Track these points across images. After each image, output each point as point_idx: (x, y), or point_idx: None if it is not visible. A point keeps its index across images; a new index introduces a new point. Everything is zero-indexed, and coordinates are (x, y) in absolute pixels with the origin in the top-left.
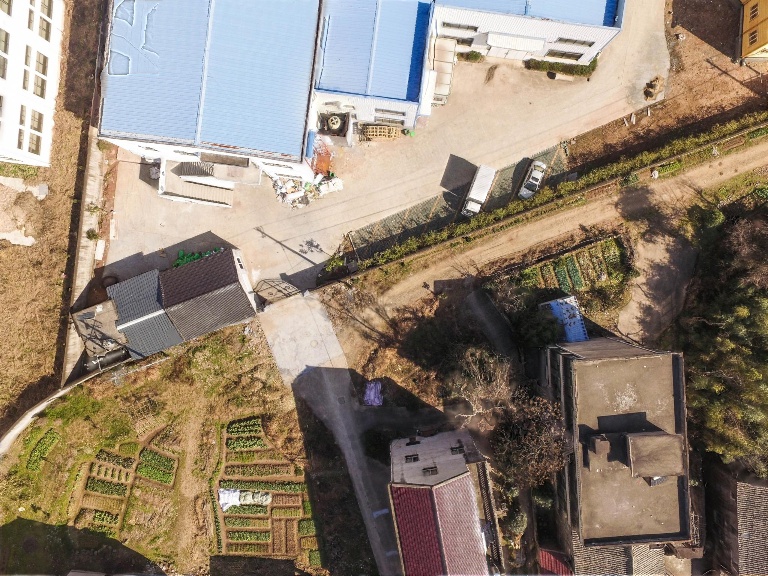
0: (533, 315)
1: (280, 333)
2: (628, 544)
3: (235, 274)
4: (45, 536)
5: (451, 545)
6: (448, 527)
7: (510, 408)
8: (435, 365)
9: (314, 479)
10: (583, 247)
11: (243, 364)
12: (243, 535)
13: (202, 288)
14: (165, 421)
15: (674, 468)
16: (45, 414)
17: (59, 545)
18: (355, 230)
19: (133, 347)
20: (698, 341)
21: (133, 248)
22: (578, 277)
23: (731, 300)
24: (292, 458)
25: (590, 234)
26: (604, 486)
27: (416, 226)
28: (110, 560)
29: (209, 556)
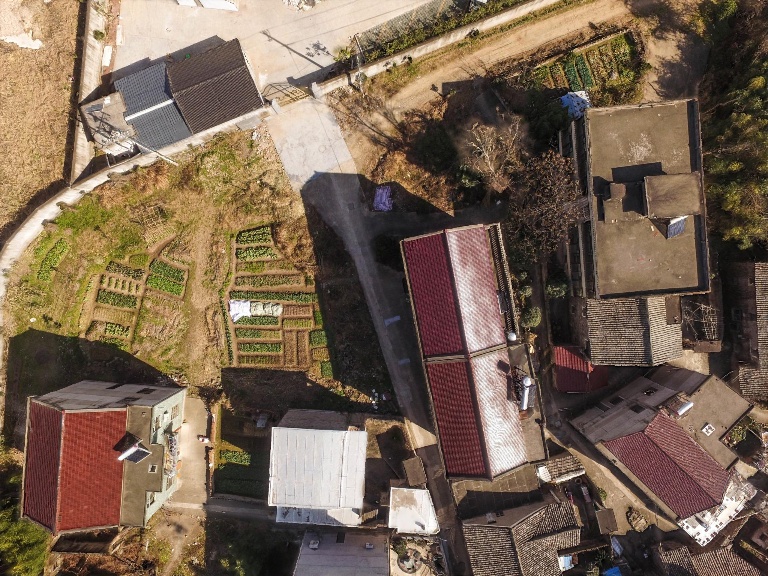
0: (543, 106)
1: (288, 138)
2: (645, 296)
3: (242, 59)
4: (57, 347)
5: (465, 292)
6: (462, 274)
7: (522, 177)
8: (445, 170)
9: (325, 288)
10: (593, 42)
11: (251, 170)
12: (254, 346)
13: (209, 73)
14: (174, 231)
15: (691, 207)
16: (55, 223)
17: (71, 356)
18: (362, 32)
19: (141, 140)
20: (712, 129)
21: (140, 54)
22: (588, 76)
23: (745, 77)
24: (302, 266)
25: (600, 31)
26: (620, 240)
27: (423, 27)
28: (122, 371)
29: (220, 368)
